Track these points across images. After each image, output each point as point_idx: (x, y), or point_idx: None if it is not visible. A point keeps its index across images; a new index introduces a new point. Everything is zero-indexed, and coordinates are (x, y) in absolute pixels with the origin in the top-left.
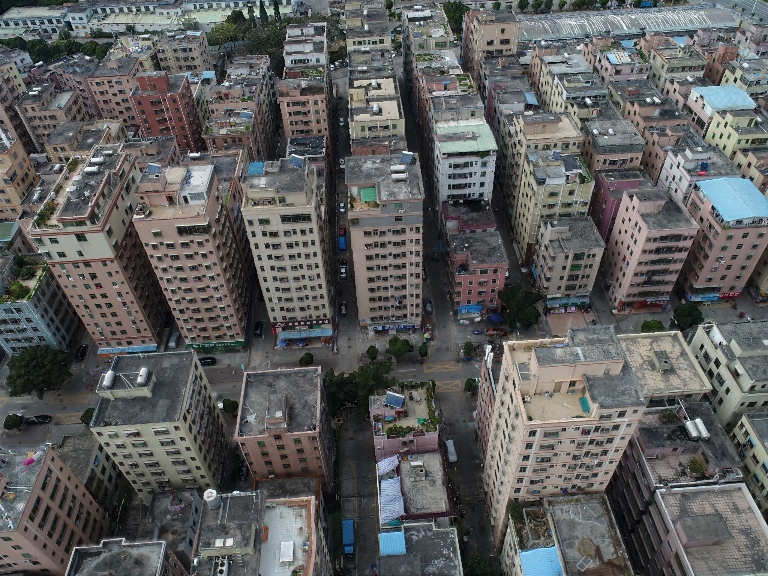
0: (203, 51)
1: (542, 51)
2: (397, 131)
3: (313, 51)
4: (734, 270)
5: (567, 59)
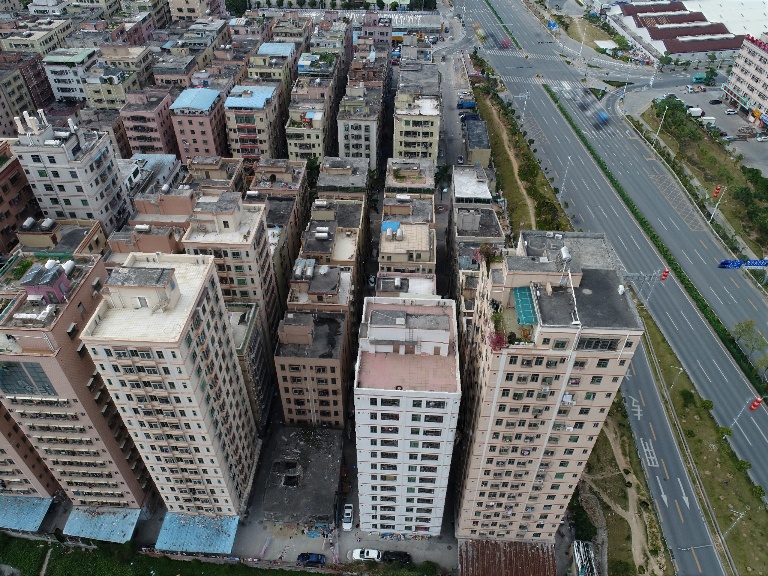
0: (10, 7)
1: (206, 17)
2: (36, 50)
3: (54, 5)
4: (202, 153)
5: (209, 21)
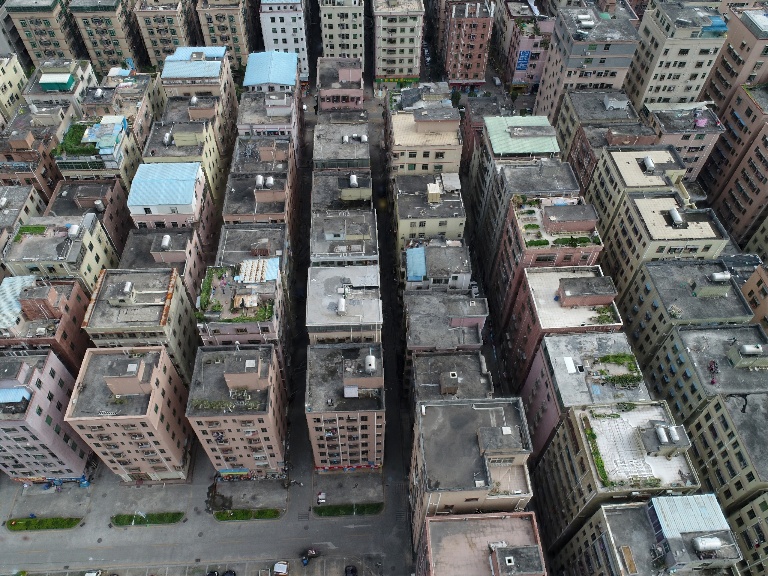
0: None
1: None
2: None
3: None
4: None
5: None
